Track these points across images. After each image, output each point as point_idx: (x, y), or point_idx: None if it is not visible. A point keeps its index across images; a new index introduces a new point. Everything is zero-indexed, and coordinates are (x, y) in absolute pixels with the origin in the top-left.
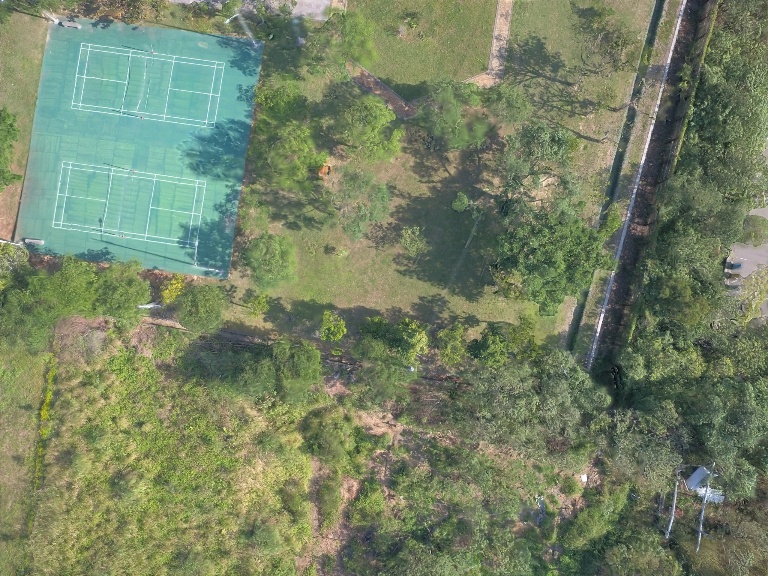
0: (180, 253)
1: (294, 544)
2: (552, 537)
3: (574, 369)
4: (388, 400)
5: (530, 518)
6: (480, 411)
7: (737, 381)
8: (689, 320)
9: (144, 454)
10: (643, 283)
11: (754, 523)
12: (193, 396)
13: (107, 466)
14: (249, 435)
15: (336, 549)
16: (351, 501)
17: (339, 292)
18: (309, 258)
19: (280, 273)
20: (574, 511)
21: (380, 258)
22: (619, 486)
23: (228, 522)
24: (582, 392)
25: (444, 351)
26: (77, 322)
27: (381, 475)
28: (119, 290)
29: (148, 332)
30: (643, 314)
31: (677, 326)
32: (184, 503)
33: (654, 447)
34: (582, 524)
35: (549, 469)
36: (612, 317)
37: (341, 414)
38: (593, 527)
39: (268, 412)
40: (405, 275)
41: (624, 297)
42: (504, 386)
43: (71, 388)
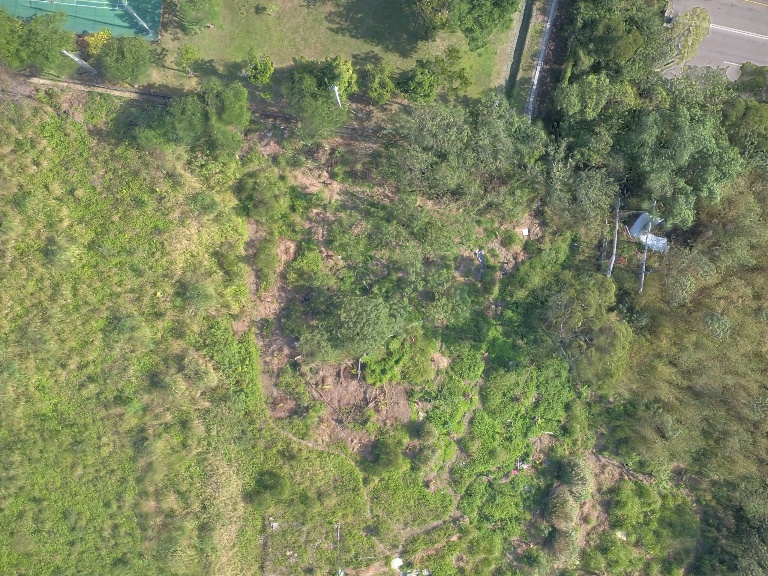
0: (110, 16)
1: (230, 301)
2: (494, 290)
3: (510, 115)
4: (321, 151)
5: (471, 274)
6: (411, 144)
7: (673, 111)
8: (622, 52)
9: (78, 221)
10: (577, 27)
11: (695, 251)
12: (125, 159)
13: (40, 233)
14: (183, 196)
15: (274, 312)
16: (289, 263)
17: (271, 52)
18: (240, 19)
19: (202, 3)
20: (516, 265)
21: (312, 17)
22: (561, 236)
23: (163, 284)
24: (519, 139)
25: (372, 84)
26: (8, 91)
27: (319, 236)
28: (43, 33)
29: (79, 98)
30: (578, 56)
31: (614, 70)
32: (118, 267)
33: (589, 173)
34: (524, 275)
35: (489, 223)
36: (551, 77)
37: (276, 174)
38: (535, 277)
39: (201, 171)
40: (337, 33)
41: (562, 55)
42: (434, 118)
43: (3, 156)
